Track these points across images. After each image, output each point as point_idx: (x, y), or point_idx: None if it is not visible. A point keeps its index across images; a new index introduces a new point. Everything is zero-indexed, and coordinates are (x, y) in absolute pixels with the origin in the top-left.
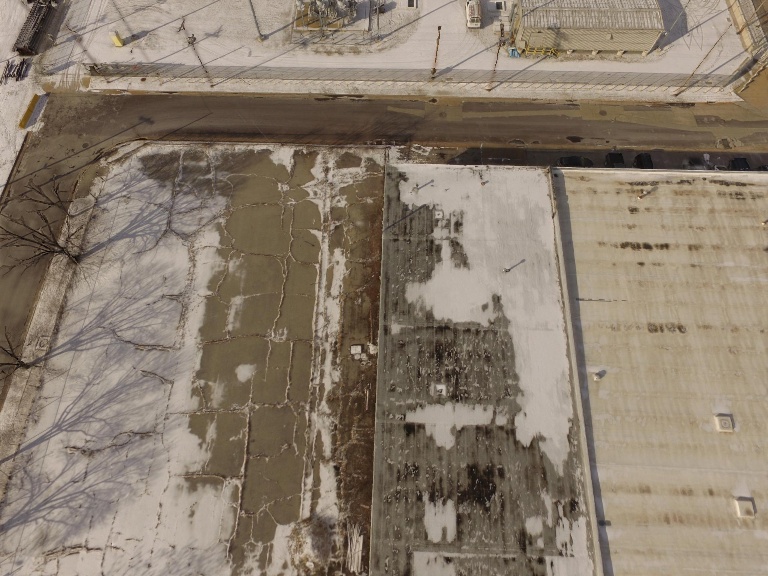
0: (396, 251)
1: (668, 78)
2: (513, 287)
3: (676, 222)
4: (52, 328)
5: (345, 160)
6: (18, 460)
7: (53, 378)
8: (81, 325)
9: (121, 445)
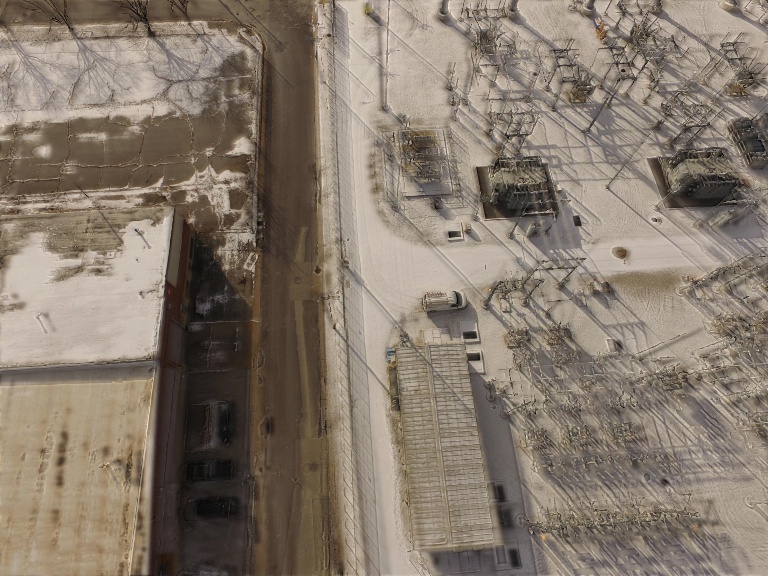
0: (77, 222)
1: (371, 571)
2: (20, 322)
3: (70, 507)
4: (98, 36)
5: (239, 196)
6: (7, 43)
7: (60, 46)
8: (98, 51)
9: (3, 91)
